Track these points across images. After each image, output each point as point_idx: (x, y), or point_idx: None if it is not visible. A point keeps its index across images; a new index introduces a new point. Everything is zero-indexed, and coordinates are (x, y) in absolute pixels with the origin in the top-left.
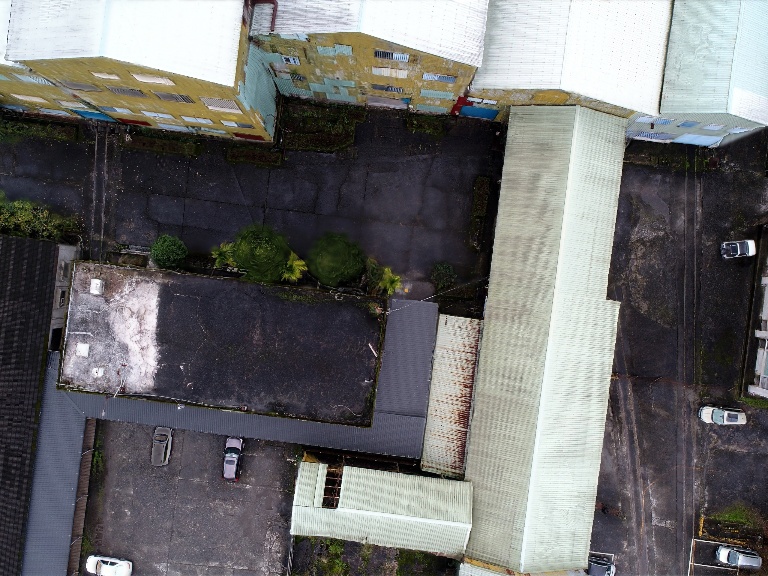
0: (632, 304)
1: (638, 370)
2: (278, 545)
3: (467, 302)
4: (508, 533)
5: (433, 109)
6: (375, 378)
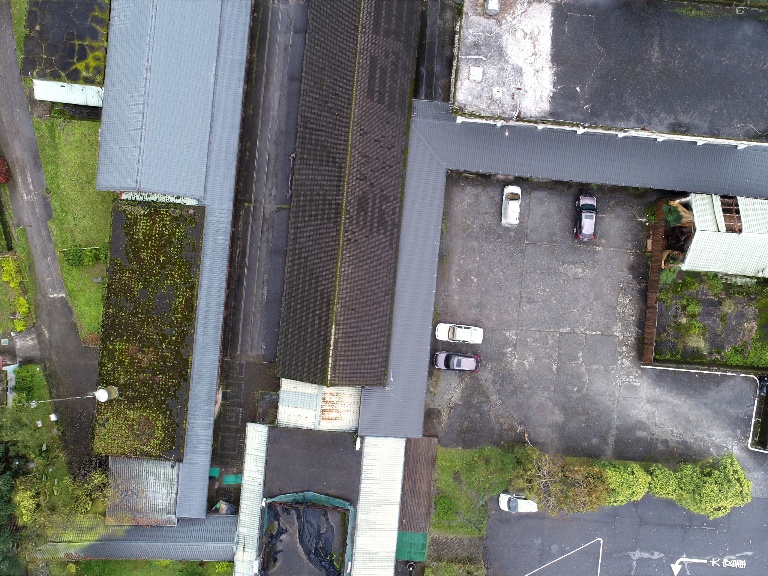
0: None
1: None
2: (631, 308)
3: None
4: None
5: None
6: None
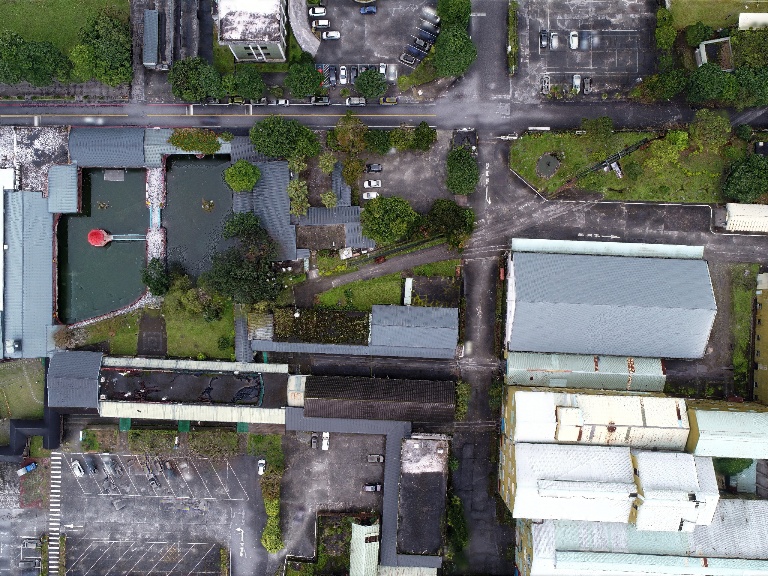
0: None
1: None
2: (339, 507)
3: (441, 574)
4: None
5: None
6: (414, 553)
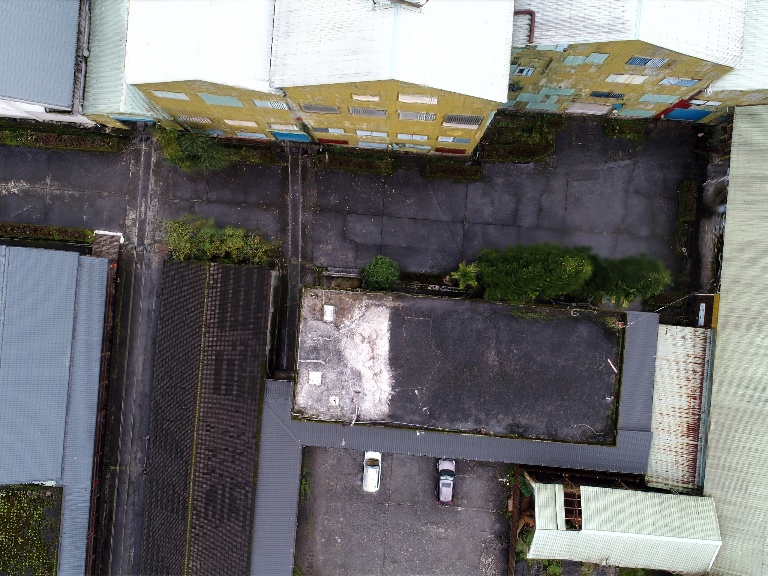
0: None
1: None
2: (494, 567)
3: (676, 310)
4: (759, 549)
5: (638, 113)
6: (616, 395)
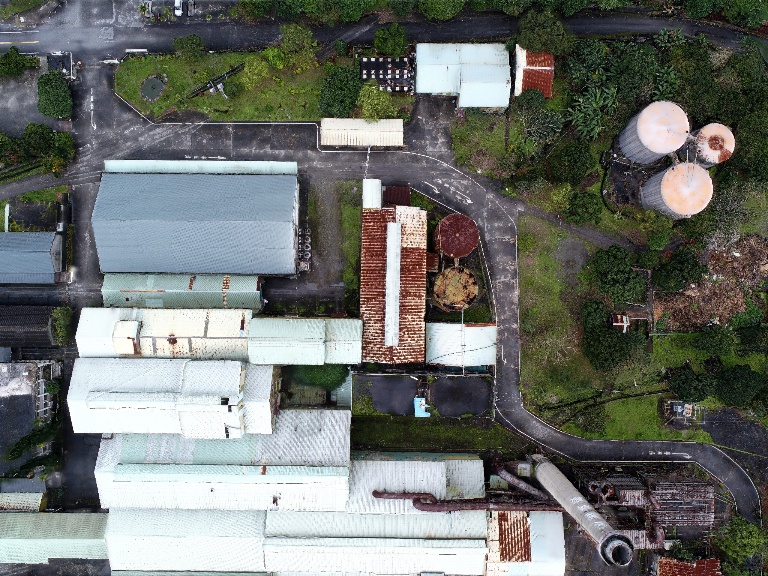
0: (60, 568)
1: (34, 573)
2: None
3: None
4: None
5: None
6: (5, 477)
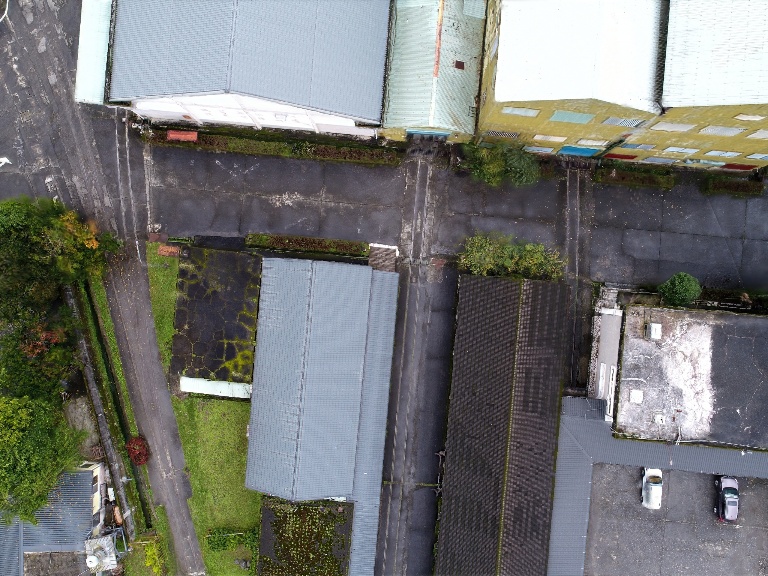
0: None
1: None
2: None
3: None
4: None
5: None
6: None
